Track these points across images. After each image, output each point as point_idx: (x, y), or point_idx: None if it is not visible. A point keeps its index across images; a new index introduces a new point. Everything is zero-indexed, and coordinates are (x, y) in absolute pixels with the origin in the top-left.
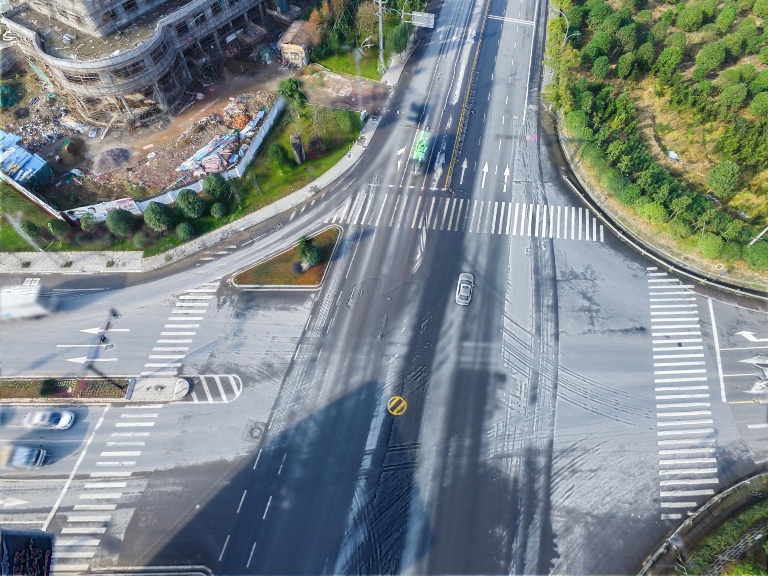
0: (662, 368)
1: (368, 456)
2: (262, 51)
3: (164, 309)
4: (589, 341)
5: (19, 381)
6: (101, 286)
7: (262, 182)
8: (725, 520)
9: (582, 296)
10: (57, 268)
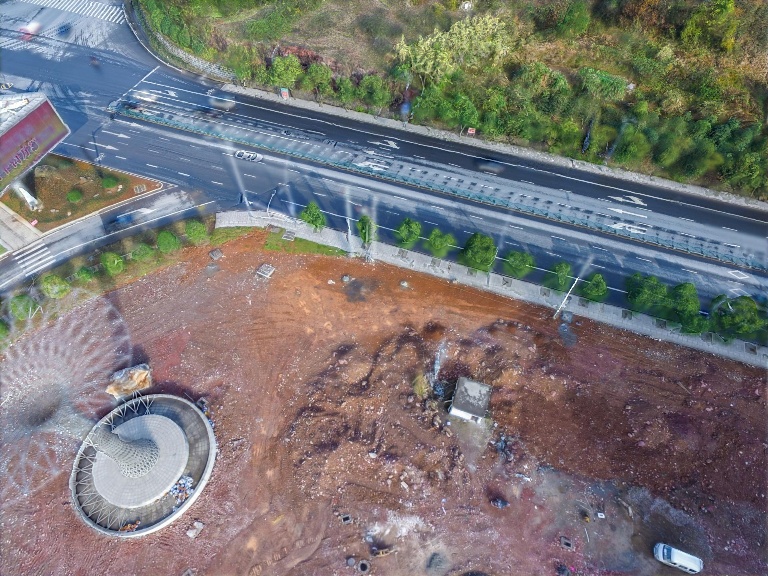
0: (65, 8)
1: None
2: None
3: None
4: (33, 24)
5: None
6: None
7: None
8: None
9: (7, 21)
10: None
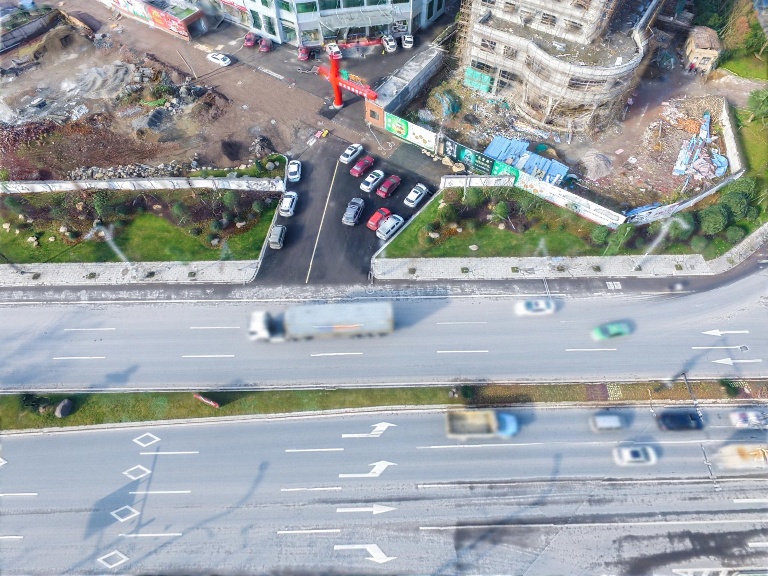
0: None
1: None
2: (667, 56)
3: (765, 311)
4: None
5: (689, 383)
6: (685, 289)
7: (764, 185)
8: None
9: None
10: (630, 272)
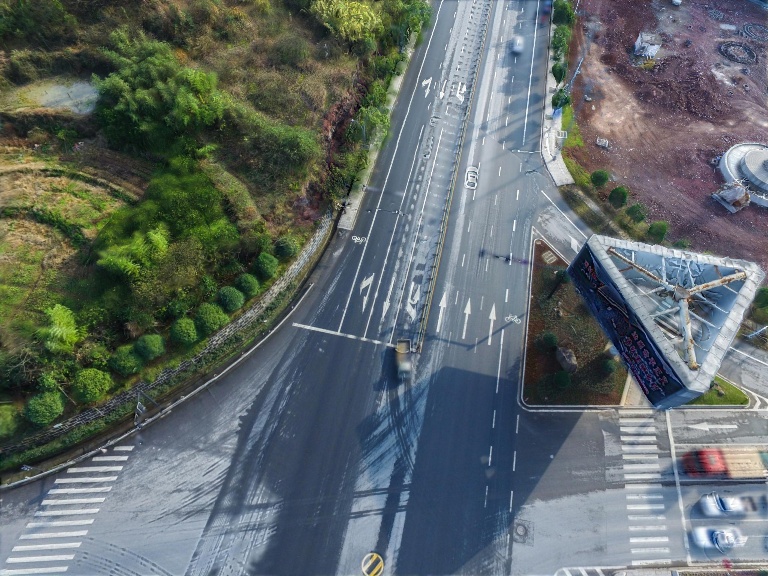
0: None
1: (403, 504)
2: None
3: None
4: None
5: None
6: None
7: None
8: (75, 445)
9: None
10: None
